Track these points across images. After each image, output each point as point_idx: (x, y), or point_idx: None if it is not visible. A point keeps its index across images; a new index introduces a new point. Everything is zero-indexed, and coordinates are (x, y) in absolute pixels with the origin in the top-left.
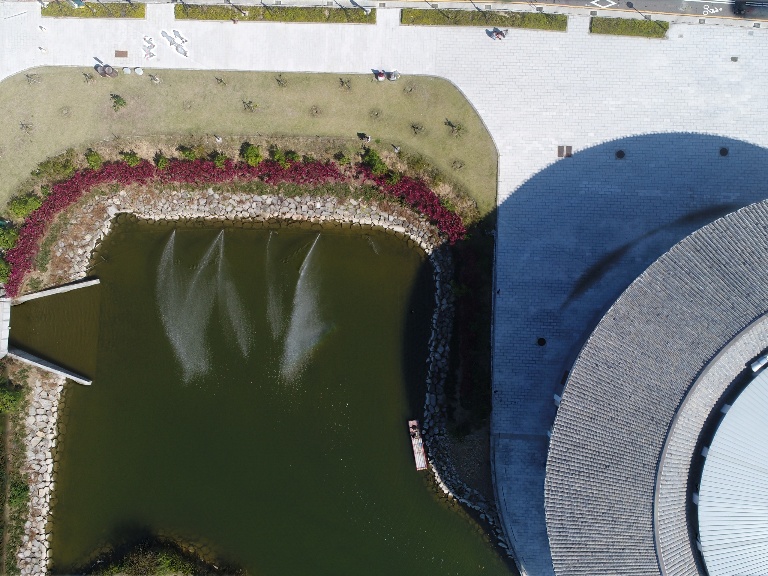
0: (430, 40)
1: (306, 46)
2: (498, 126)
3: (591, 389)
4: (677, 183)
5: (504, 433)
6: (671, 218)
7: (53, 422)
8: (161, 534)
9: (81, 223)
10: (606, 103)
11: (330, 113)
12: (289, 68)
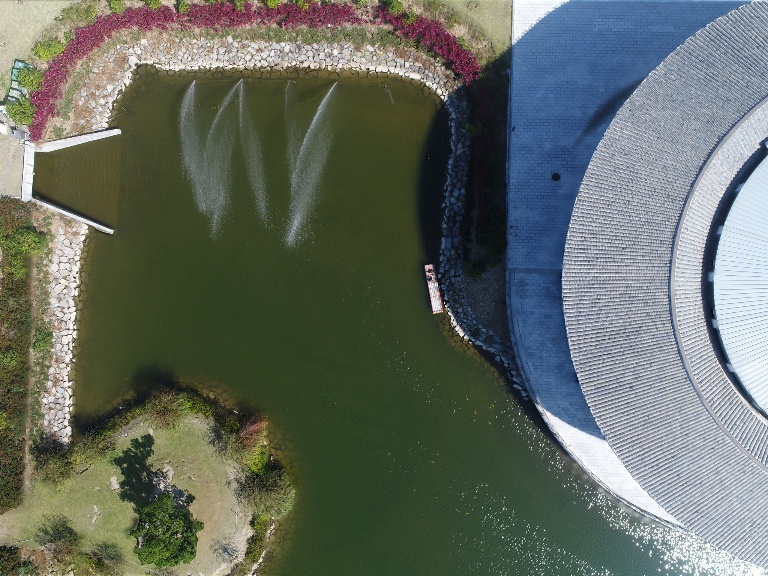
0: None
1: None
2: None
3: (608, 178)
4: (689, 19)
5: (519, 268)
6: None
7: (76, 271)
8: (182, 381)
9: (103, 72)
10: None
11: None
12: None
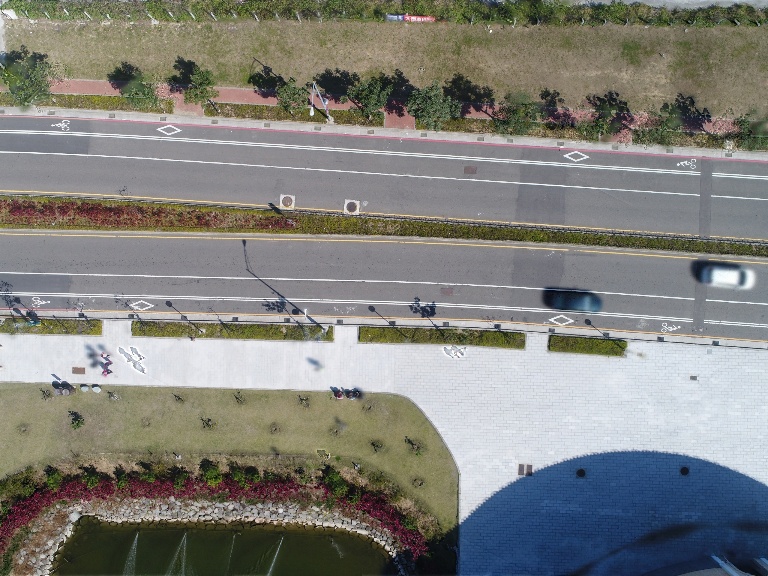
0: (388, 358)
1: (264, 363)
2: (458, 444)
3: None
4: (638, 502)
5: None
6: (633, 538)
7: None
8: None
9: (43, 531)
10: (566, 421)
11: (289, 430)
12: (247, 385)
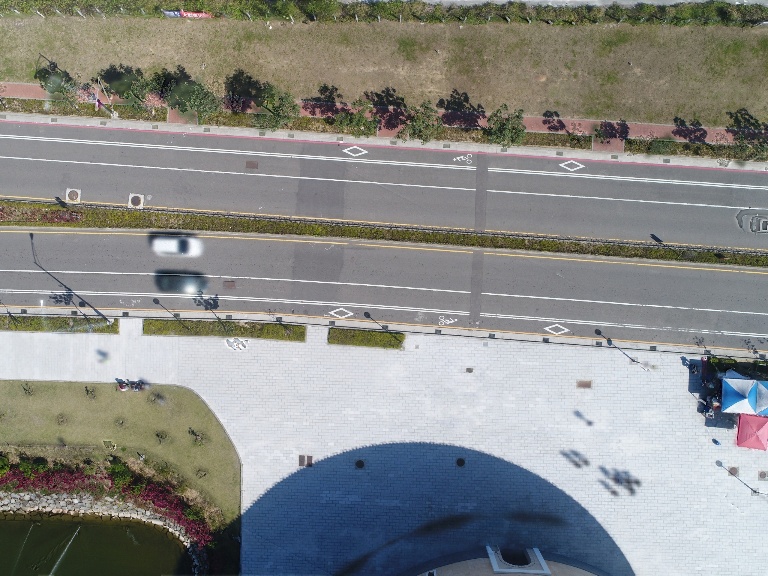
0: (172, 350)
1: (51, 355)
2: (240, 435)
3: None
4: (415, 493)
5: None
6: (410, 528)
7: None
8: None
9: None
10: (345, 413)
11: (76, 421)
12: (35, 377)
